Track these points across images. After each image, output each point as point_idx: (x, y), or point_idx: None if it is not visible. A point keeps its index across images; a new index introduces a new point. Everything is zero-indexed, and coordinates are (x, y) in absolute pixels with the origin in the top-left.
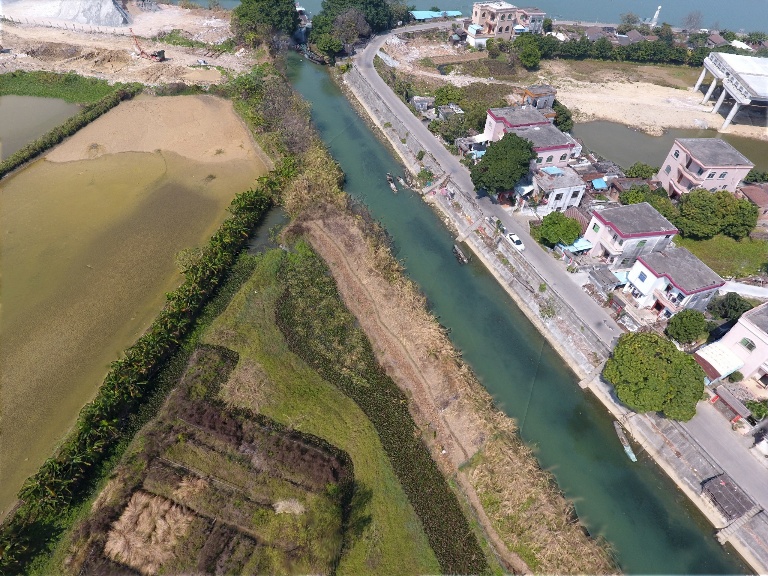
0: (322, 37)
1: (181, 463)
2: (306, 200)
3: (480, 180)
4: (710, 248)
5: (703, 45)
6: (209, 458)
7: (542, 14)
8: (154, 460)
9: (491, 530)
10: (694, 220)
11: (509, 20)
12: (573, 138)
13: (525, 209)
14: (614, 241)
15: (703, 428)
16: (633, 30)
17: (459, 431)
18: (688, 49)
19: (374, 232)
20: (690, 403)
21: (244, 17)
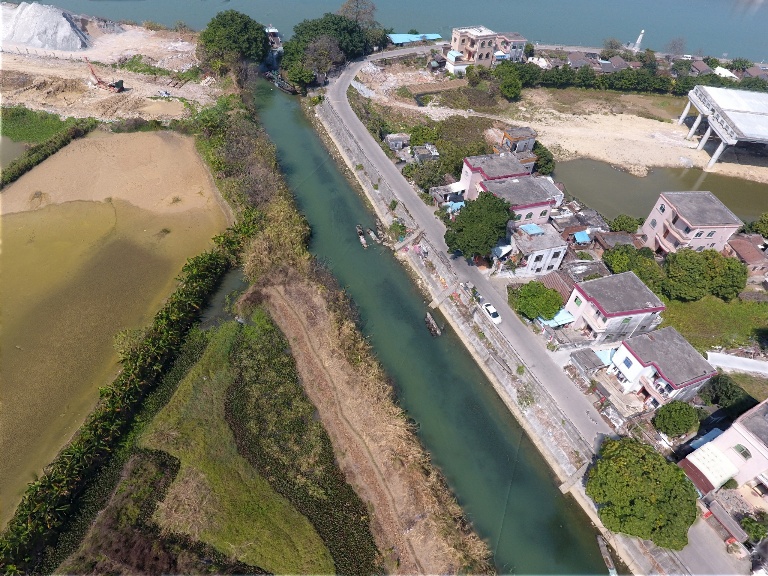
0: (293, 65)
1: None
2: (266, 263)
3: (454, 242)
4: (698, 311)
5: (687, 73)
6: None
7: (523, 40)
8: None
9: None
10: (681, 282)
11: (489, 47)
12: (555, 182)
13: (503, 272)
14: (597, 316)
15: (695, 551)
16: (616, 56)
17: (425, 559)
18: (672, 78)
19: (338, 306)
20: (682, 533)
21: (210, 43)
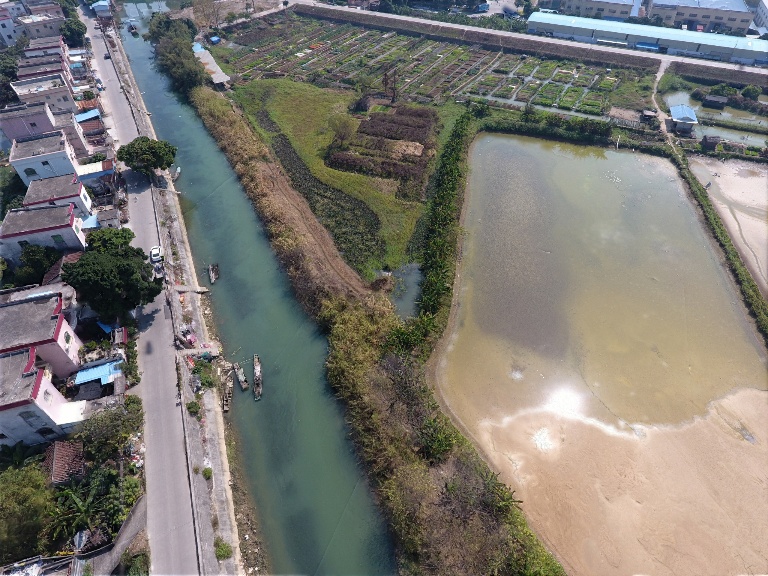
0: None
1: None
2: None
3: None
4: None
5: None
6: None
7: None
8: None
9: None
10: None
11: None
12: None
13: None
14: None
15: None
16: None
17: None
18: None
19: None
20: None
21: None
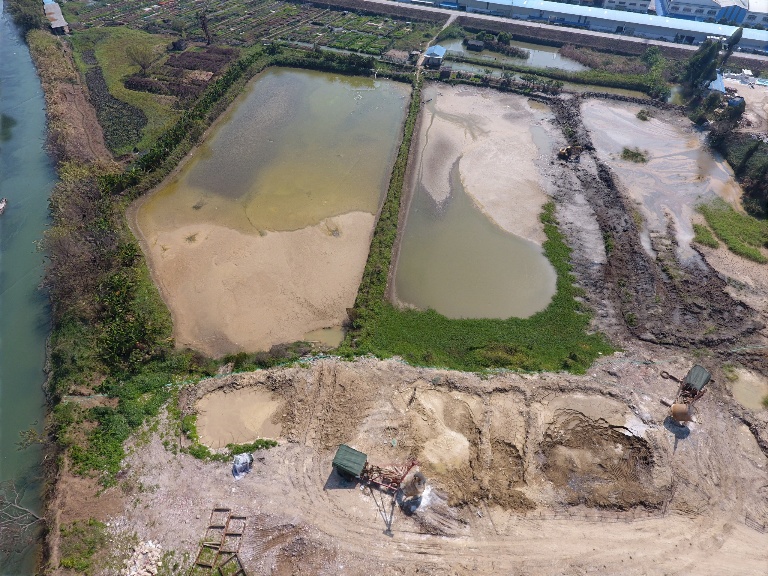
0: None
1: None
2: None
3: None
4: None
5: None
6: None
7: None
8: None
9: None
10: None
11: None
12: None
13: None
14: None
15: None
16: None
17: None
18: None
19: None
20: None
21: None
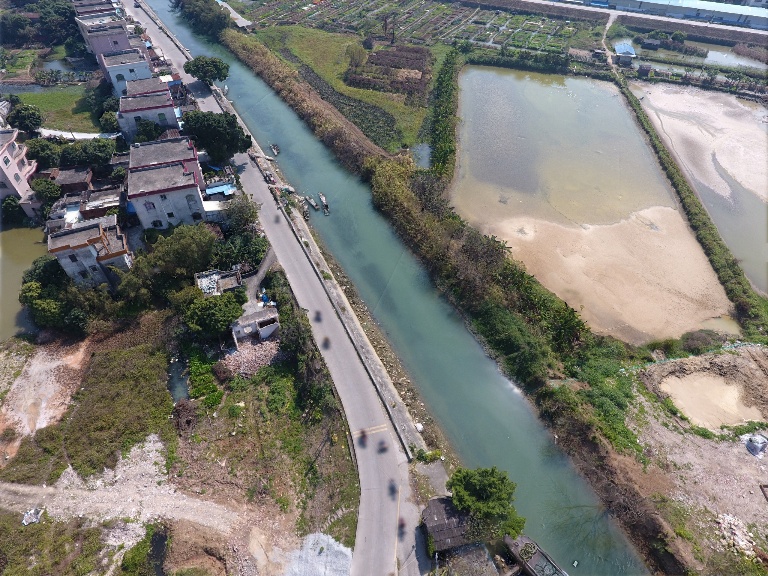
0: None
1: None
2: None
3: None
4: None
5: None
6: None
7: None
8: None
9: None
10: None
11: None
12: None
13: None
14: None
15: None
16: None
17: None
18: None
19: None
20: None
21: None
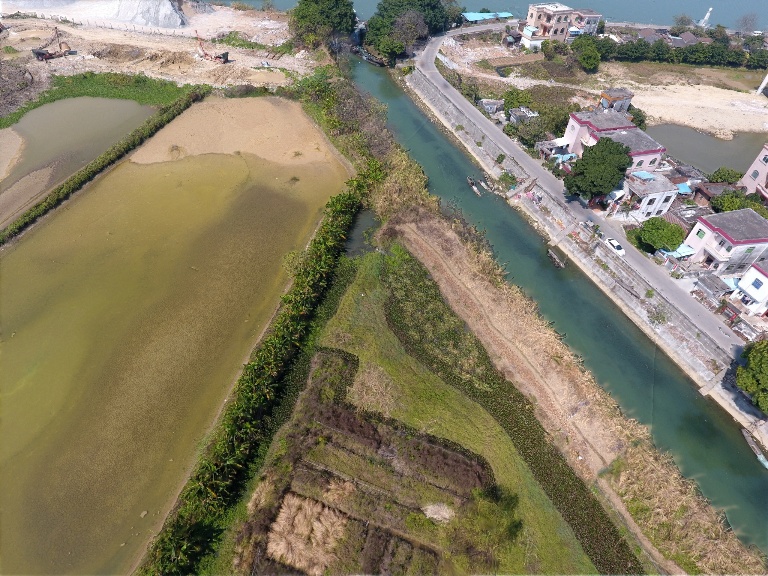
0: (381, 39)
1: (324, 466)
2: (398, 203)
3: (574, 184)
4: None
5: (760, 47)
6: (351, 461)
7: (598, 16)
8: (298, 462)
9: (642, 537)
10: None
11: (565, 22)
12: None
13: (618, 214)
14: (720, 247)
15: None
16: (687, 32)
17: (593, 437)
18: (746, 51)
19: (475, 236)
20: None
21: (303, 19)
